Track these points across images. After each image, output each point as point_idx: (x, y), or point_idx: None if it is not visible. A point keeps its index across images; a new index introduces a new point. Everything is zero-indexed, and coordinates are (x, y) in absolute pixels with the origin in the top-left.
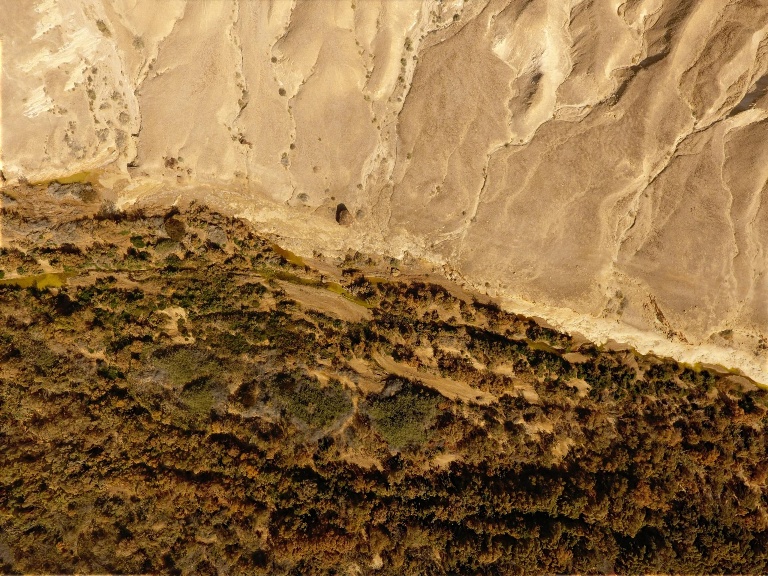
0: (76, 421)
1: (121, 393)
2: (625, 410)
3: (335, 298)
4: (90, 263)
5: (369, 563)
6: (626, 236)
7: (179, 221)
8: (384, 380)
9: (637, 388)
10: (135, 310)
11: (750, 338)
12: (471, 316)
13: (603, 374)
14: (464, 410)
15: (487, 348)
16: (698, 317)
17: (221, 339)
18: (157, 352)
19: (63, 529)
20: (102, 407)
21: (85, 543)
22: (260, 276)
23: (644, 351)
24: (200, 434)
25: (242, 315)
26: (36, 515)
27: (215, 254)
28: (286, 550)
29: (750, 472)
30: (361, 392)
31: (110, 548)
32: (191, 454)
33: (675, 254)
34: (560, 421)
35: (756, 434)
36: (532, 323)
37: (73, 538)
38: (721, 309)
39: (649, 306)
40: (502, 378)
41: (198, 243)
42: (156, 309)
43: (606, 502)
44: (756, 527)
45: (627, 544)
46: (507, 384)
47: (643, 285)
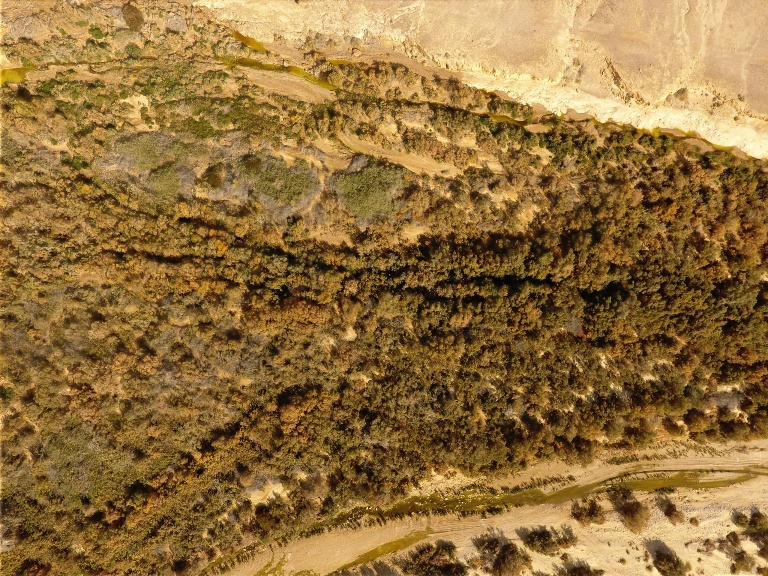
0: (41, 205)
1: (87, 182)
2: (587, 175)
3: (298, 81)
4: (49, 55)
5: (343, 335)
6: (580, 1)
7: (137, 9)
8: (350, 158)
9: (598, 153)
10: (97, 99)
11: (704, 97)
12: (433, 90)
13: (564, 141)
14: (430, 182)
15: (450, 119)
16: (653, 75)
17: (185, 124)
18: (121, 139)
19: (34, 318)
20: (68, 194)
21: (57, 330)
22: (222, 63)
23: (603, 119)
24: (168, 216)
25: (205, 99)
26: (6, 303)
27: (175, 37)
28: (259, 320)
29: (709, 226)
30: (327, 170)
31: (83, 334)
32: (160, 236)
33: (628, 13)
34: (524, 188)
35: (714, 191)
36: (493, 96)
37: (45, 326)
38: (675, 66)
39: (606, 71)
40: (466, 150)
41: (157, 31)
42: (118, 98)
43: (571, 255)
44: (717, 276)
45: (593, 299)
46: (471, 153)
47: (599, 49)
